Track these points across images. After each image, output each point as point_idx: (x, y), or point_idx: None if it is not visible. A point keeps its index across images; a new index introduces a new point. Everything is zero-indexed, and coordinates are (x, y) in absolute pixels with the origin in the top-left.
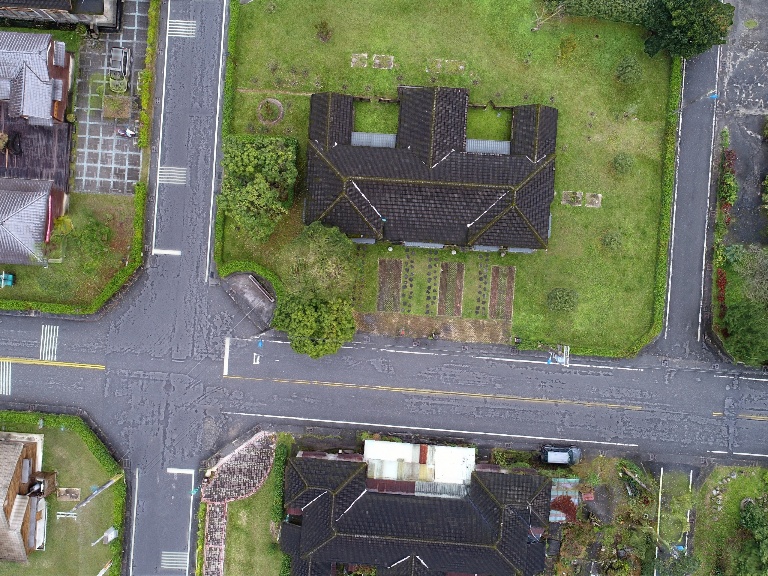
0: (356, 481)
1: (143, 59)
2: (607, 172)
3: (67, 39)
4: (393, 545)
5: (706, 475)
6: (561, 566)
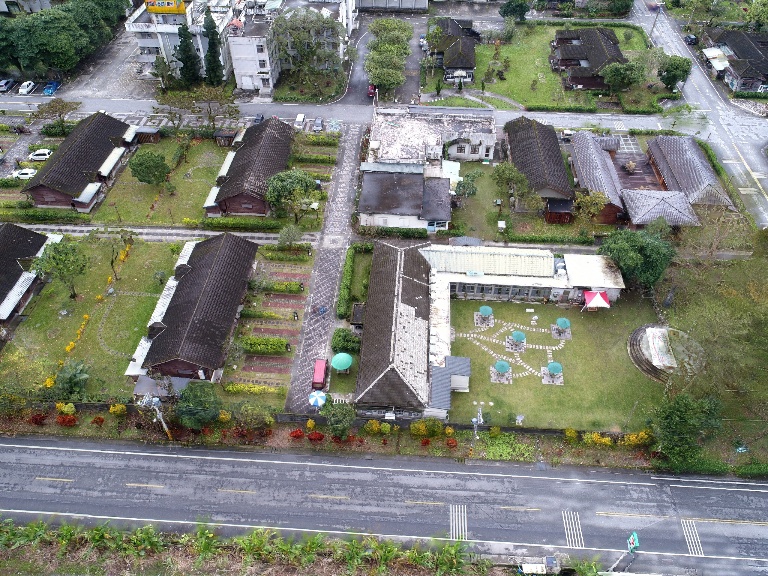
0: None
1: None
2: None
3: None
4: None
5: None
6: None
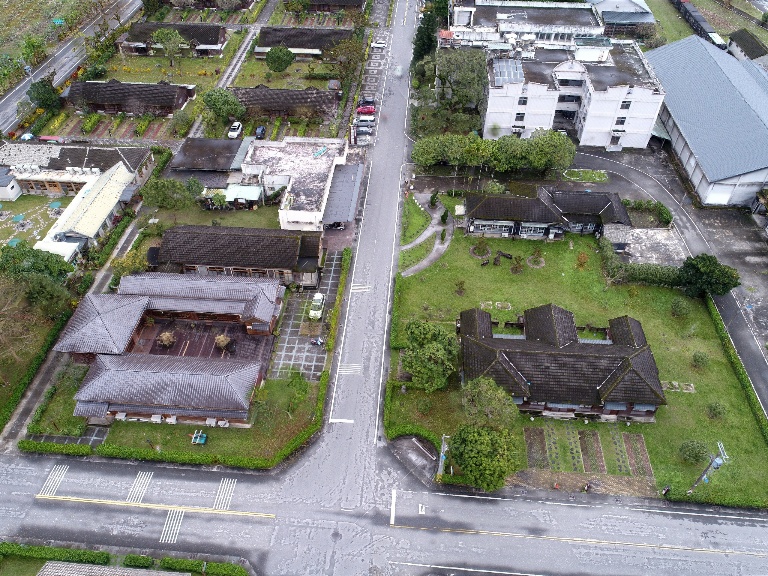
0: None
1: (333, 303)
2: (691, 369)
3: None
4: None
5: None
6: None
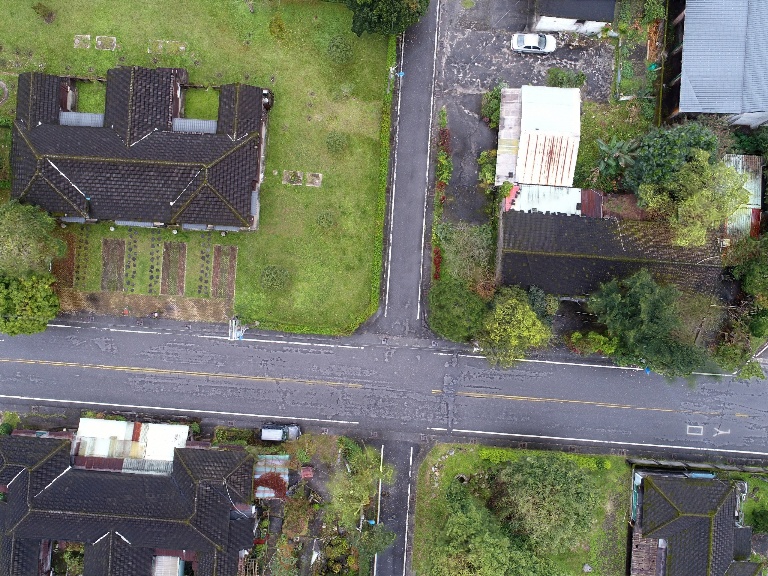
0: (57, 458)
1: None
2: (327, 151)
3: None
4: (89, 521)
5: (426, 452)
6: (278, 543)
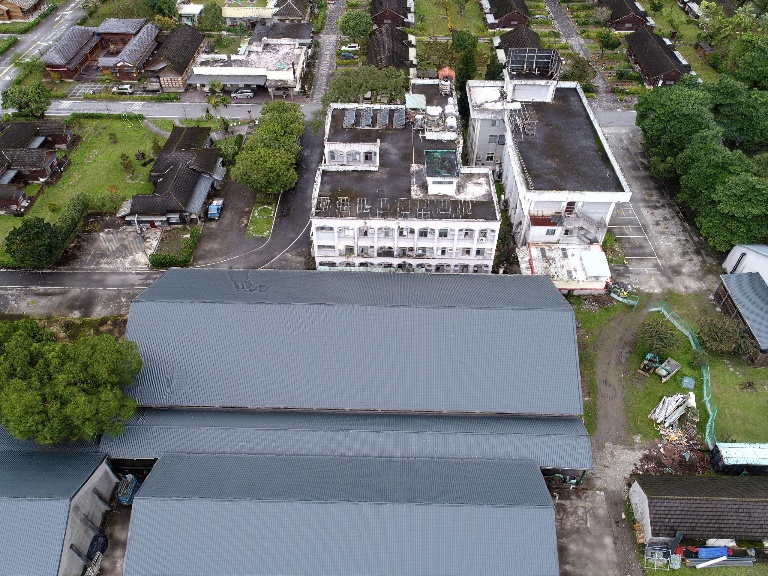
0: None
1: None
2: None
3: None
4: None
5: None
6: None
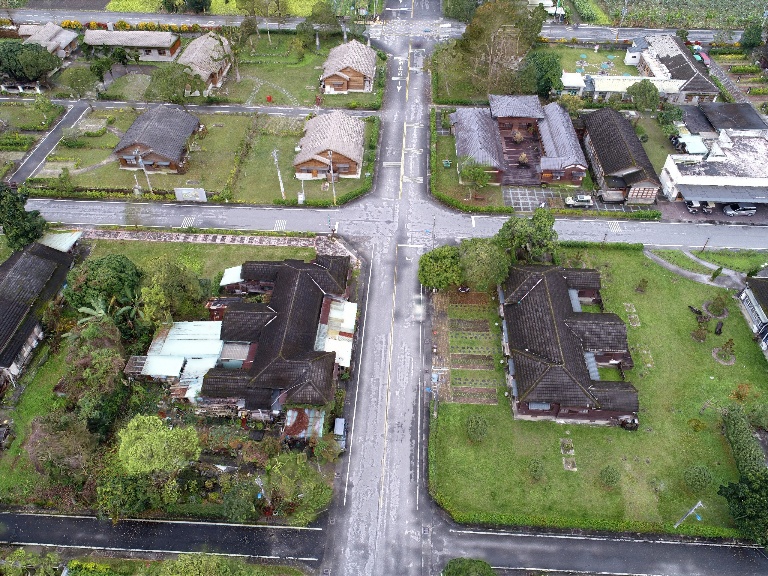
0: (333, 286)
1: None
2: None
3: (589, 185)
4: None
5: (311, 575)
6: None
